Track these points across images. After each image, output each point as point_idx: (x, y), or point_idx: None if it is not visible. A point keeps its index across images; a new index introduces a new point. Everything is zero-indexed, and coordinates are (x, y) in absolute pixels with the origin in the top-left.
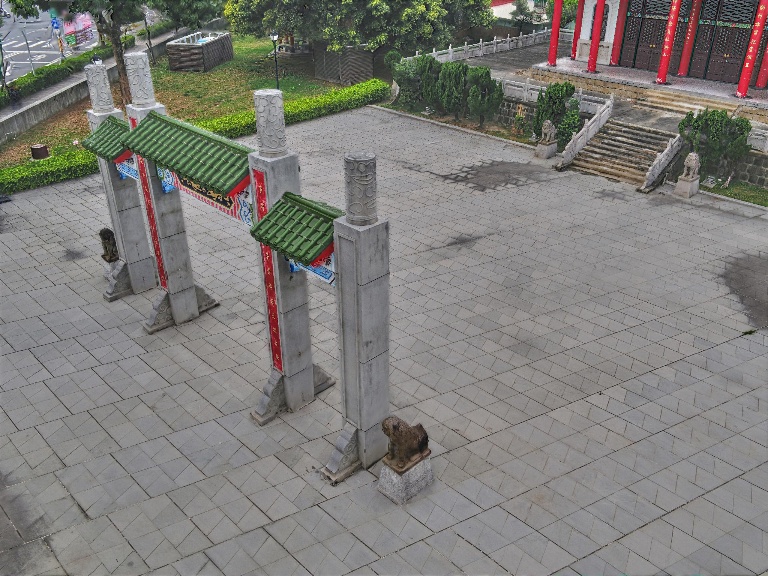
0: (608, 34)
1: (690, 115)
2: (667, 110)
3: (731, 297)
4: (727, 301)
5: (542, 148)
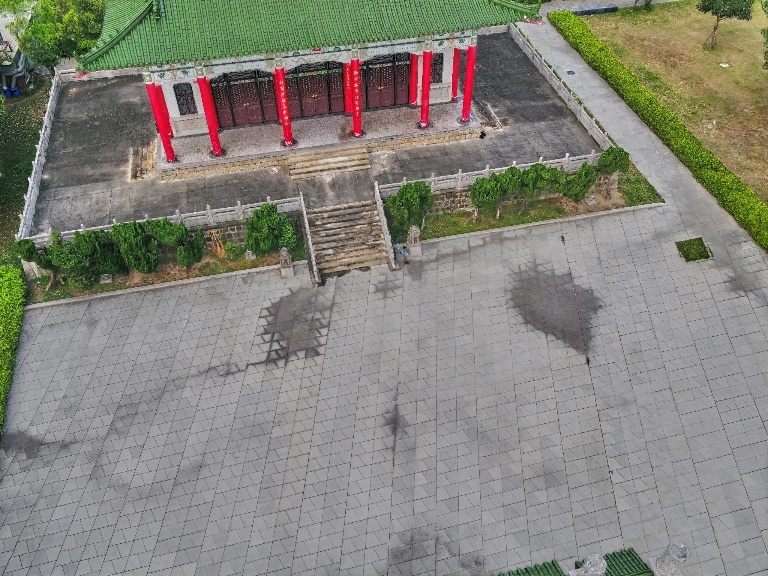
0: (200, 107)
1: (392, 198)
2: (320, 171)
3: (550, 338)
4: (553, 343)
5: (288, 271)
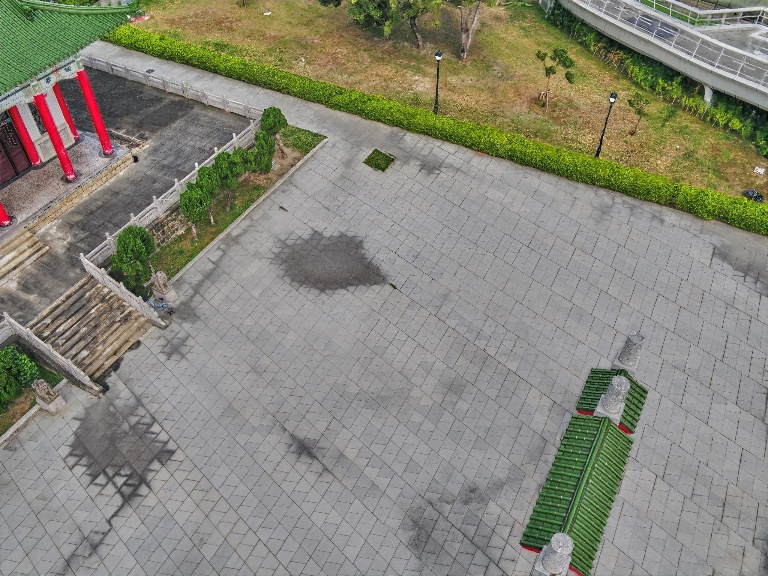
0: None
1: None
2: None
3: (352, 289)
4: (358, 291)
5: (57, 402)
